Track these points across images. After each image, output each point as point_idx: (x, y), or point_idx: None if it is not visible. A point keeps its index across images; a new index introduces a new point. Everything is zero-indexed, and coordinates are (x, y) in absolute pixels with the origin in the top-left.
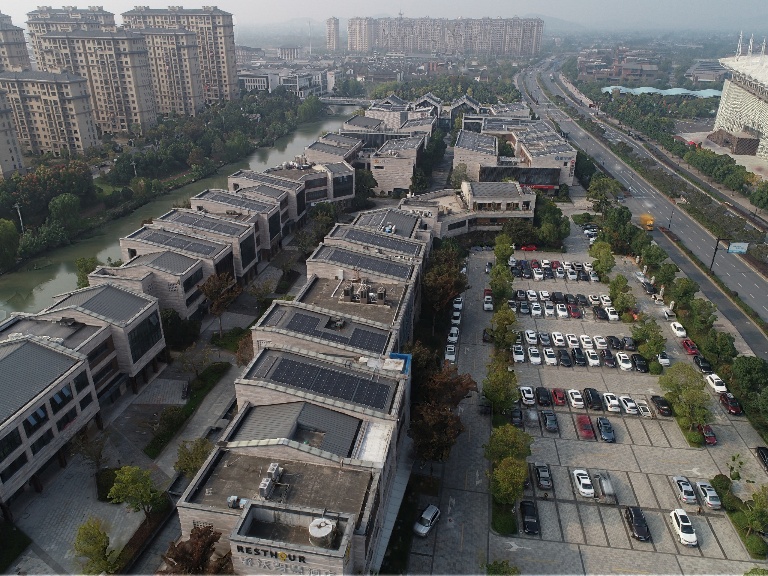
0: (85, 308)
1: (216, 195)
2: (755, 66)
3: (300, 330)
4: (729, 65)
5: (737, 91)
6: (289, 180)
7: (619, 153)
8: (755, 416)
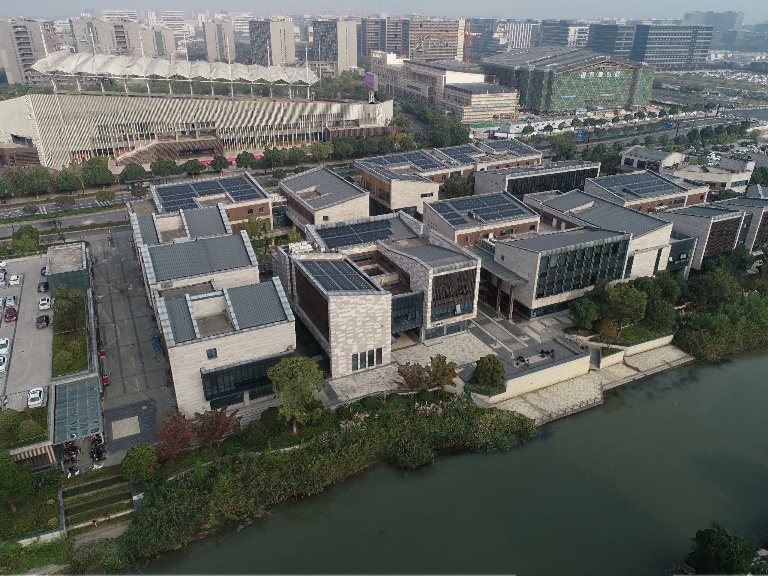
0: None
1: None
2: None
3: None
4: (86, 70)
5: (99, 102)
6: None
7: None
8: None
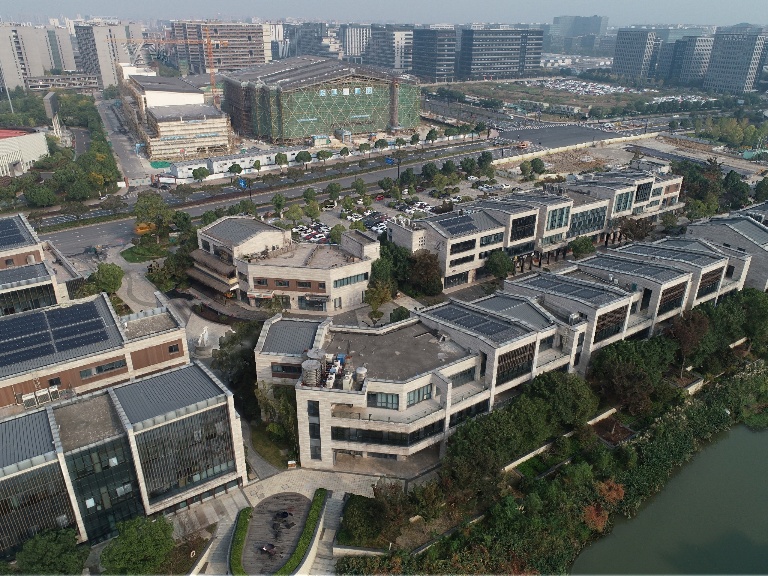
0: (740, 220)
1: (590, 297)
2: None
3: (611, 184)
4: None
5: None
6: None
7: None
8: (422, 186)
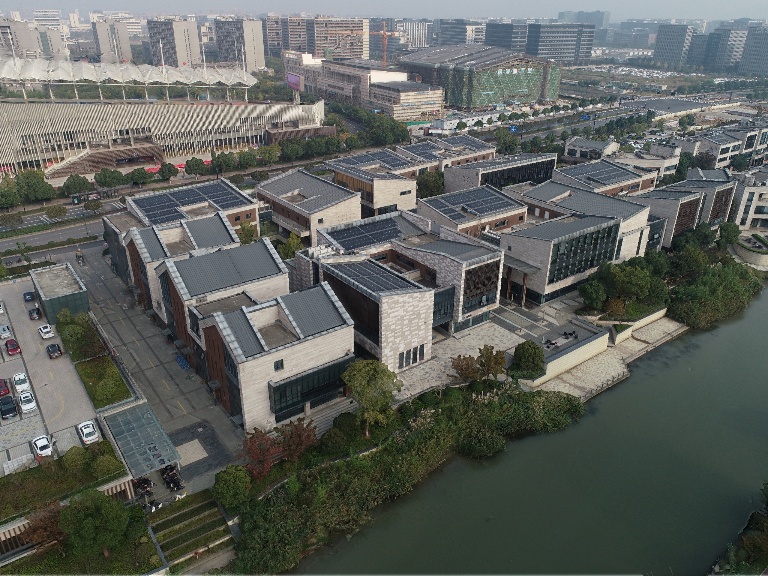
0: None
1: None
2: (39, 71)
3: None
4: (7, 76)
5: (22, 110)
6: (767, 168)
7: (247, 187)
8: None
